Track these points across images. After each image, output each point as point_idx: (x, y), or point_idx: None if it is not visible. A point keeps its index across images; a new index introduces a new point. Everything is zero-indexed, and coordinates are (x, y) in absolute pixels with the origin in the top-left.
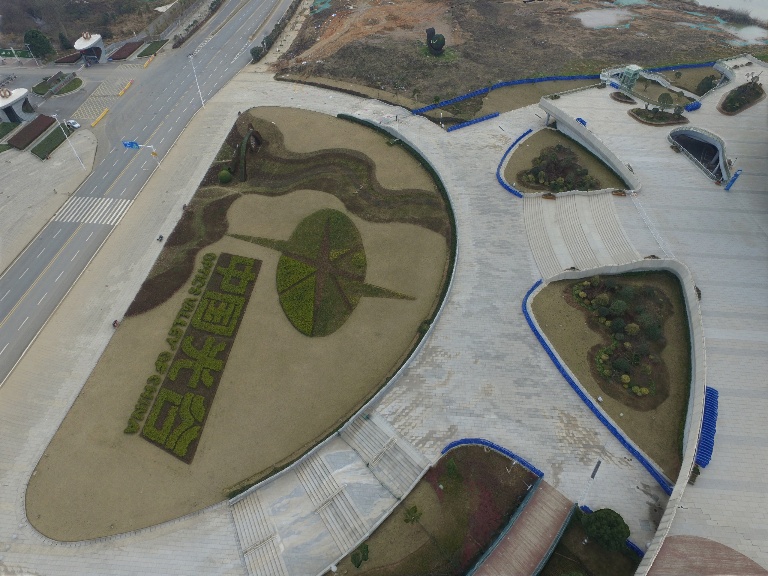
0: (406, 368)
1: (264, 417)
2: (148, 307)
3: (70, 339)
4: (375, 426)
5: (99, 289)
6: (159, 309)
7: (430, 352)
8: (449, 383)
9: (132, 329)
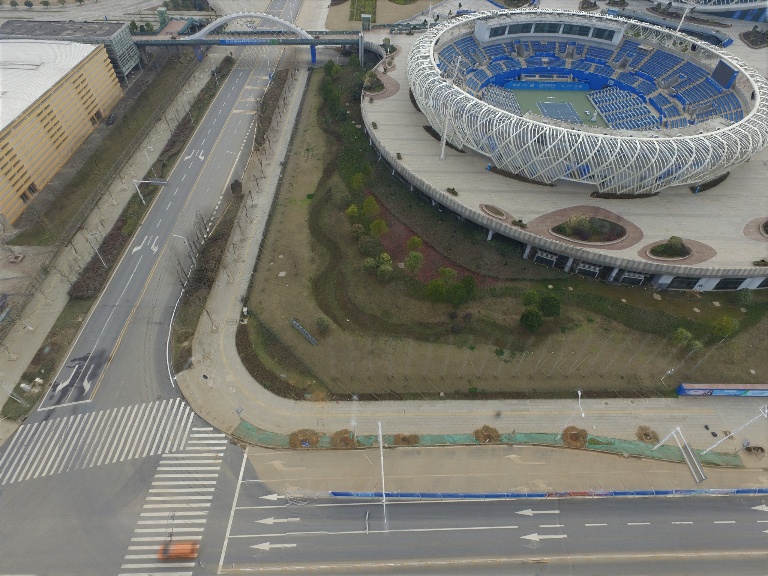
0: (441, 4)
1: (395, 16)
2: (338, 4)
3: (313, 10)
4: (434, 12)
5: (314, 2)
6: (342, 4)
7: (449, 2)
8: (457, 6)
9: (335, 8)
